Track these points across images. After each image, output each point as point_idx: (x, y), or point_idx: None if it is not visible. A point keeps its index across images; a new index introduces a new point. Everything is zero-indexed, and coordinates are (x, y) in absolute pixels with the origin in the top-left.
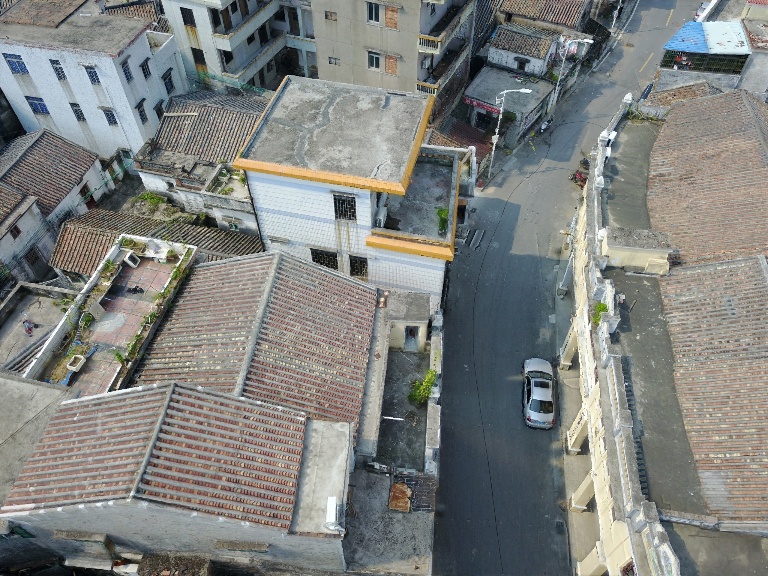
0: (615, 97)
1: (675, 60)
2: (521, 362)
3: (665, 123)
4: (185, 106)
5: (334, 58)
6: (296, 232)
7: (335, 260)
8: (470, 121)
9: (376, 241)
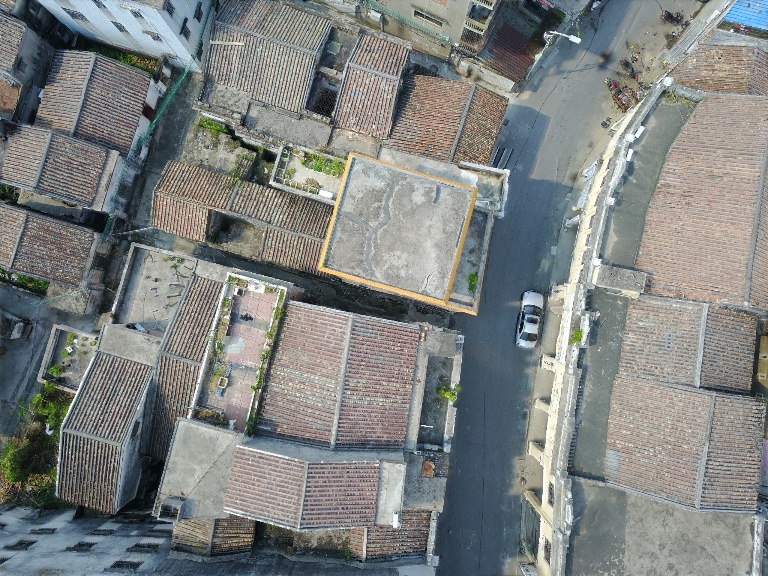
0: None
1: (733, 26)
2: (521, 290)
3: (693, 118)
4: (230, 32)
5: None
6: None
7: None
8: None
9: None
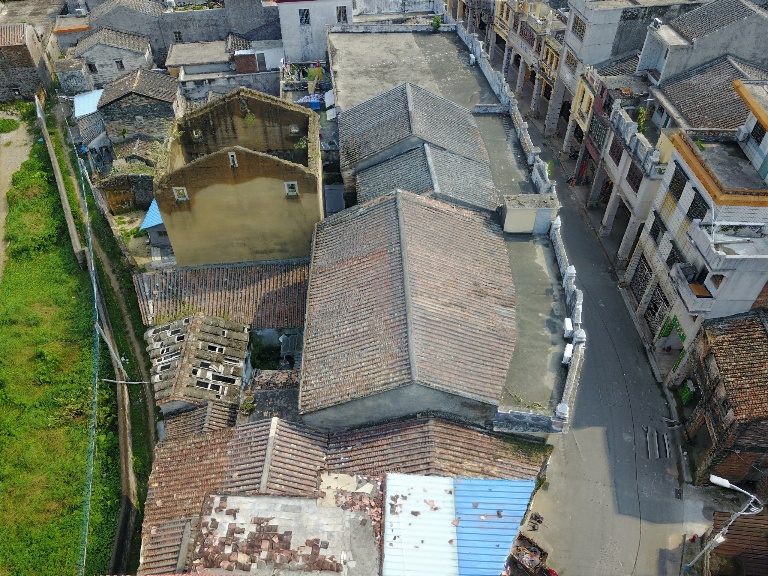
0: None
1: None
2: None
3: None
4: None
5: None
6: None
7: None
8: None
9: None
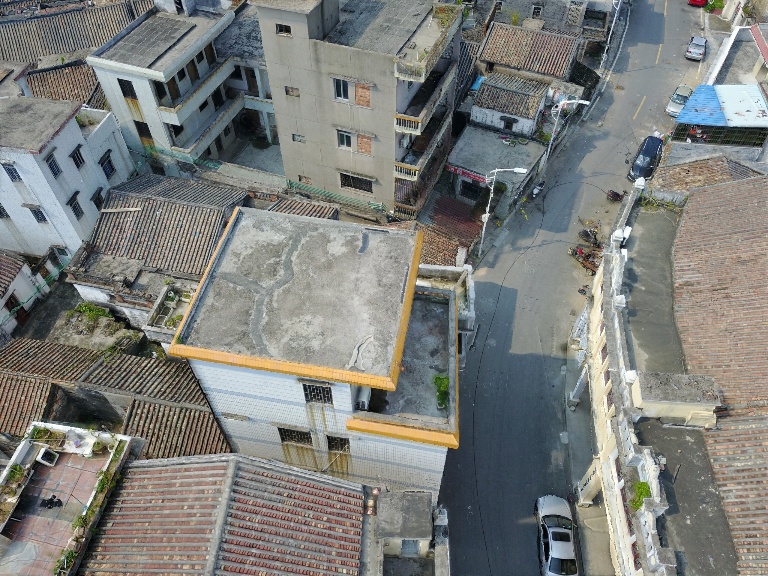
0: (610, 151)
1: (688, 133)
2: (533, 499)
3: (685, 214)
4: (126, 200)
5: (298, 135)
6: (257, 411)
7: (308, 436)
8: (454, 187)
9: (359, 426)
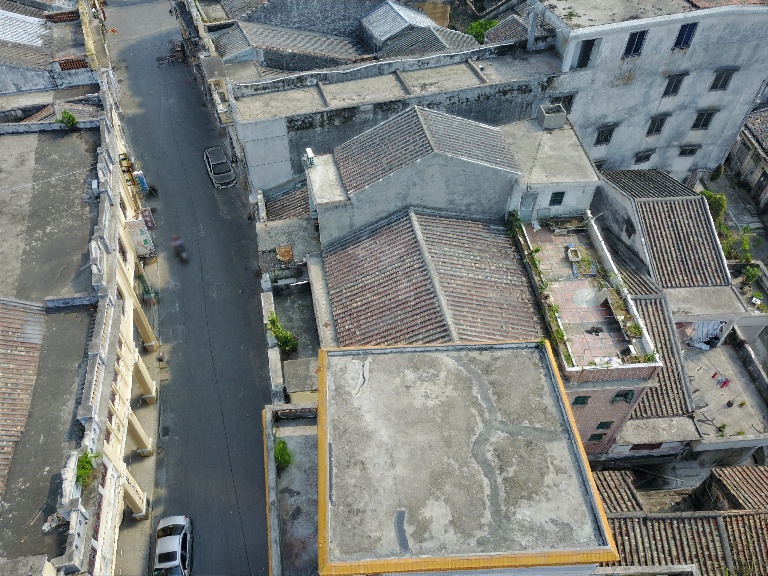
0: None
1: None
2: None
3: None
4: None
5: None
6: None
7: None
8: None
9: None
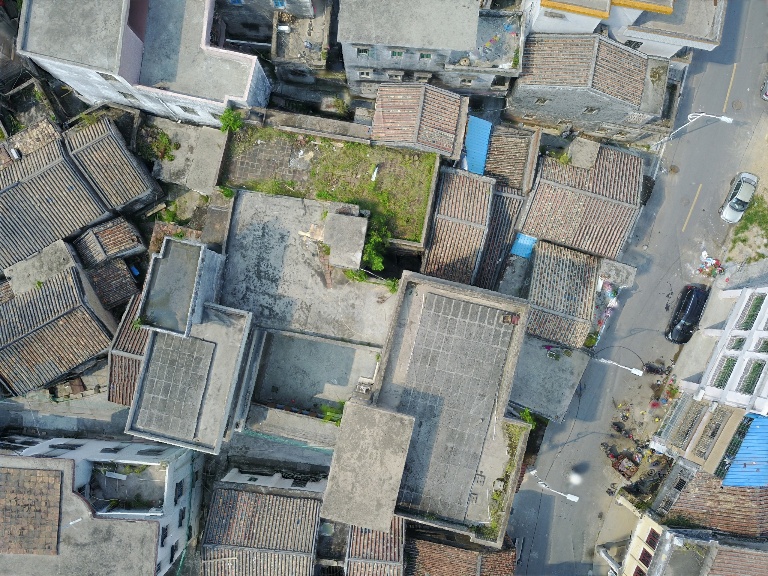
0: (652, 292)
1: None
2: None
3: (711, 572)
4: (220, 551)
5: None
6: None
7: None
8: None
9: None
